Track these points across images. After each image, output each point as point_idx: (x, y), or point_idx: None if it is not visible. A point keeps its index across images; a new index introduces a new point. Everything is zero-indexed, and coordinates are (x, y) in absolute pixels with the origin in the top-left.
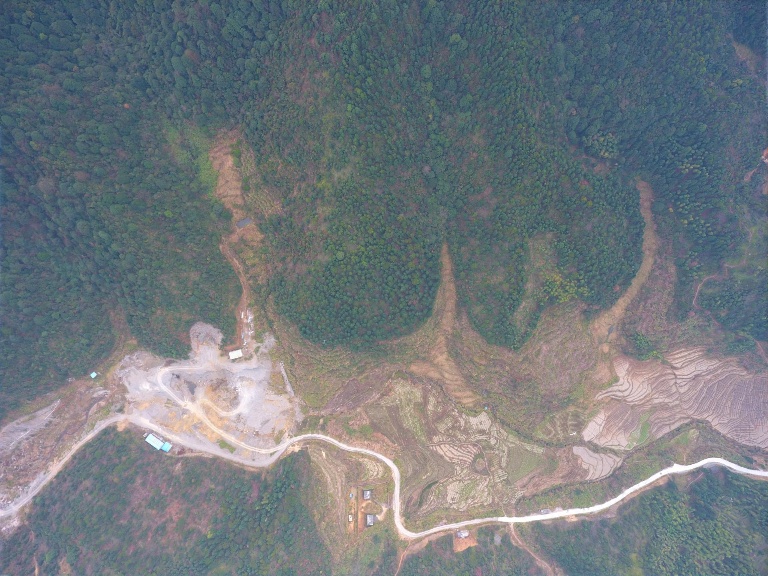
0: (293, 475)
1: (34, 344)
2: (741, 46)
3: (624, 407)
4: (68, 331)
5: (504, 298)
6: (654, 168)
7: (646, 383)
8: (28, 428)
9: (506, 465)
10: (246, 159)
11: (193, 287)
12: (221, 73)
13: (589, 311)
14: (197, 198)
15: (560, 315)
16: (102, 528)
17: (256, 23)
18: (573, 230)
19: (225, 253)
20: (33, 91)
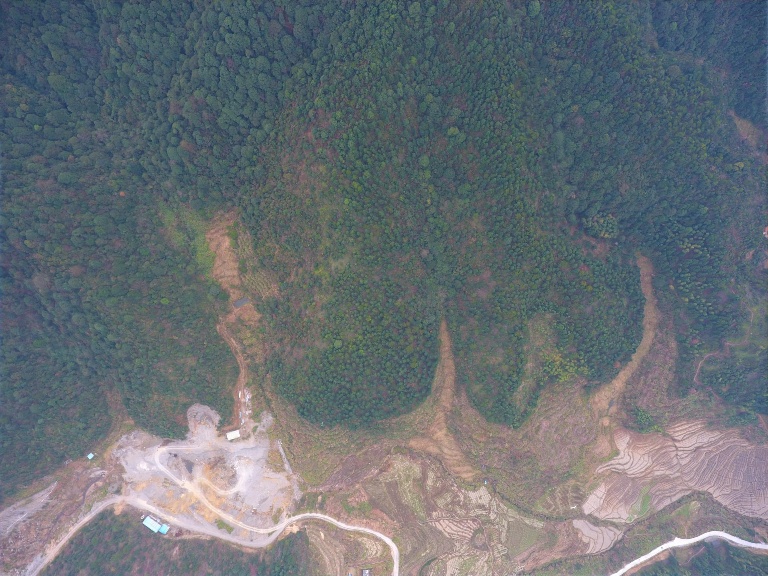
0: (291, 560)
1: (30, 430)
2: (742, 121)
3: (625, 480)
4: (64, 416)
5: (503, 379)
6: (655, 245)
7: (647, 456)
8: (25, 511)
9: (506, 540)
10: (243, 241)
11: (190, 373)
12: (217, 161)
13: (589, 386)
14: (194, 279)
15: (560, 391)
16: None
17: (252, 112)
18: (573, 312)
19: (222, 333)
20: (27, 189)
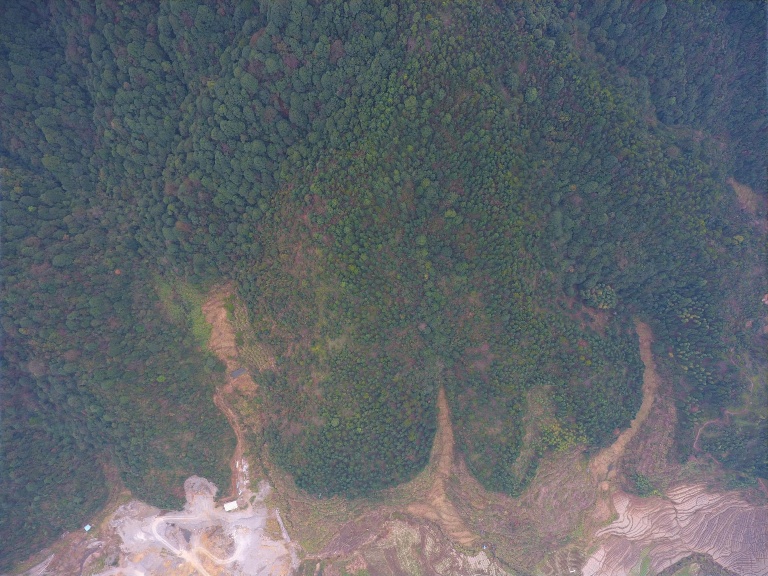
0: None
1: (27, 507)
2: (742, 186)
3: (624, 543)
4: (61, 492)
5: (502, 451)
6: (654, 313)
7: (646, 519)
8: None
9: None
10: (239, 314)
11: (187, 448)
12: (213, 239)
13: (588, 451)
14: (190, 351)
15: (559, 458)
16: None
17: (248, 191)
18: (571, 384)
19: (219, 404)
20: (22, 275)
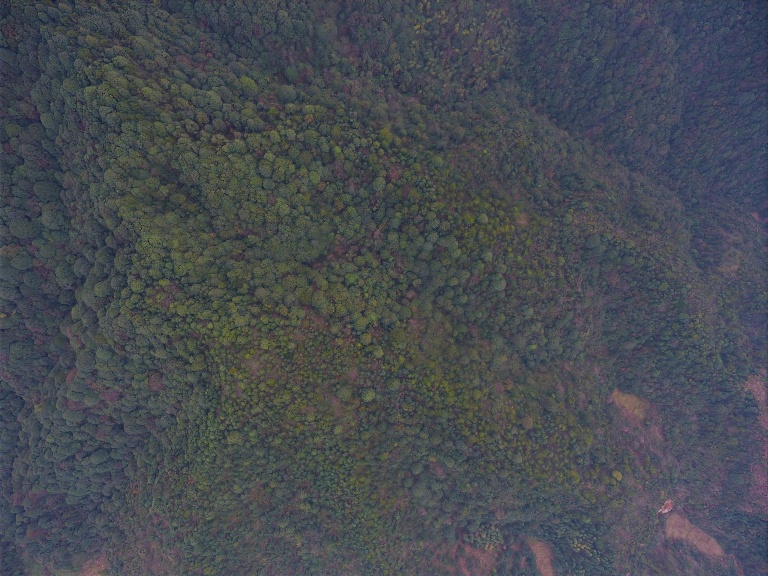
0: None
1: None
2: (627, 396)
3: None
4: None
5: None
6: None
7: None
8: None
9: None
10: None
11: None
12: (72, 533)
13: None
14: None
15: None
16: None
17: (100, 488)
18: None
19: None
20: None
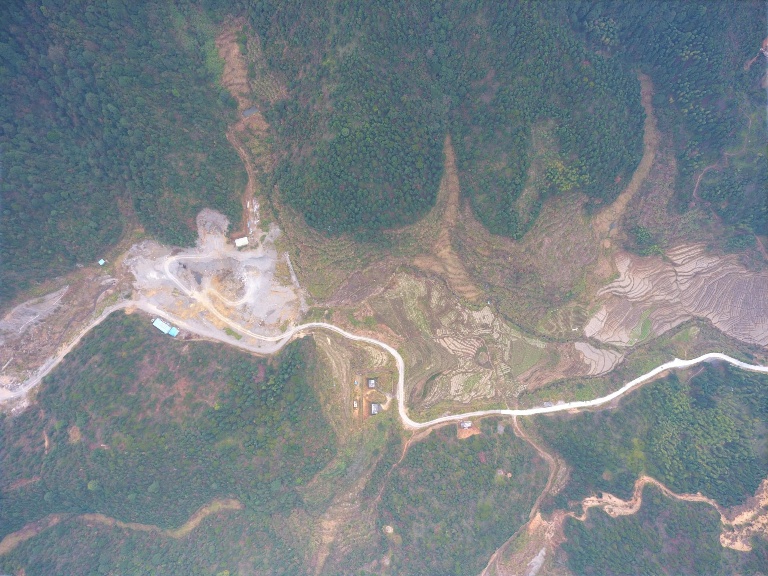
0: (299, 356)
1: (43, 225)
2: None
3: (625, 304)
4: (77, 213)
5: (507, 183)
6: (655, 58)
7: (647, 280)
8: (37, 312)
9: (509, 359)
10: (252, 45)
11: (200, 168)
12: None
13: (591, 205)
14: (203, 85)
15: (562, 207)
16: (111, 397)
17: None
18: (575, 115)
19: (231, 142)
20: None
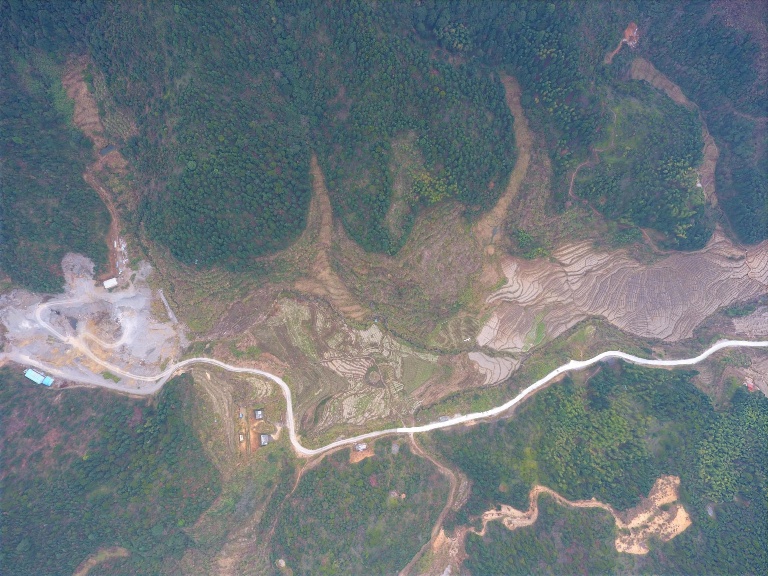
0: (173, 395)
1: None
2: None
3: (517, 309)
4: None
5: (372, 201)
6: (515, 59)
7: (537, 283)
8: None
9: (401, 376)
10: (98, 83)
11: (53, 214)
12: None
13: (469, 213)
14: (55, 128)
15: (438, 218)
16: None
17: None
18: (433, 125)
19: (90, 182)
20: None
